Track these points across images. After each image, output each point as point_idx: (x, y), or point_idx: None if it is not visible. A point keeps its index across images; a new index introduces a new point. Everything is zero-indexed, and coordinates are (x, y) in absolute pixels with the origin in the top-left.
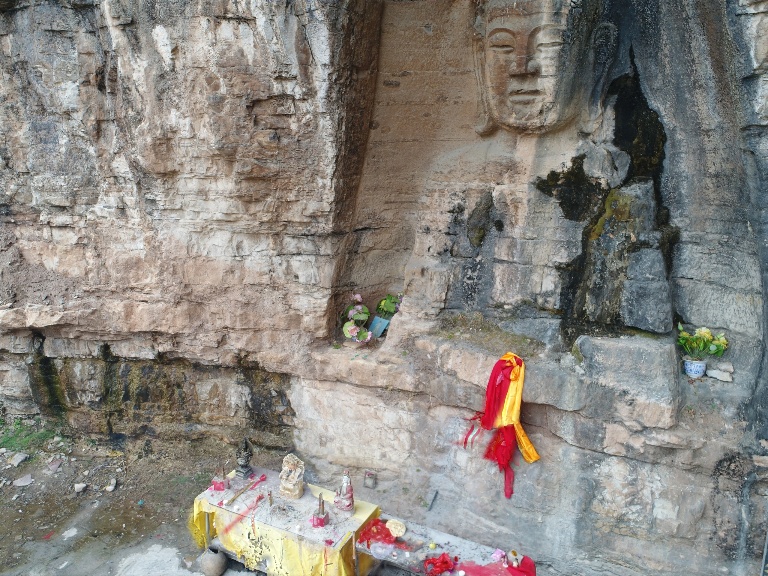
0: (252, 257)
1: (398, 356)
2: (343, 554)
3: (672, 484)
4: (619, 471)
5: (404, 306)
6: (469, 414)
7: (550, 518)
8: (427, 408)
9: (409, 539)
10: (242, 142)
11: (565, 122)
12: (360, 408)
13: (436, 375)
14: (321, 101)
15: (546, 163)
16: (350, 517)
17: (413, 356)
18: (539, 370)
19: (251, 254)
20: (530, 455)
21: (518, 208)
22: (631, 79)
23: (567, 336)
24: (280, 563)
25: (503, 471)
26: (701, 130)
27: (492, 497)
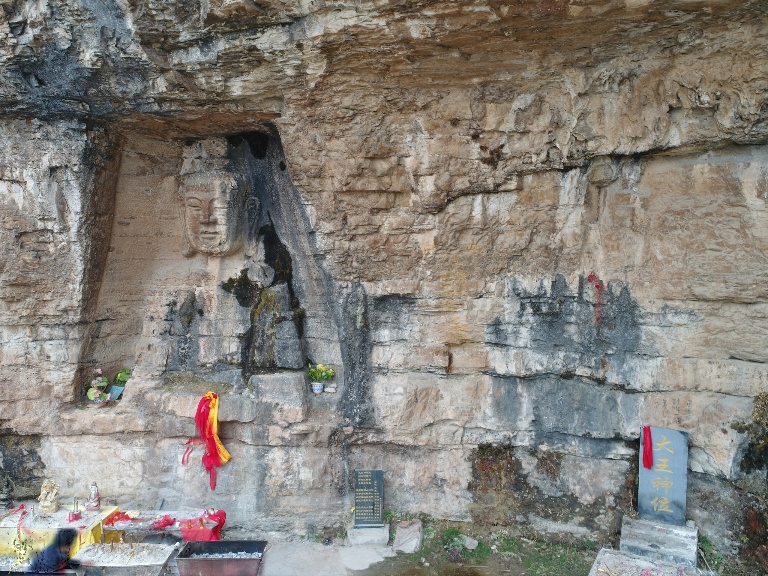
0: (10, 344)
1: (132, 407)
2: (94, 533)
3: (308, 457)
4: (279, 455)
5: (136, 372)
6: (185, 440)
7: (240, 496)
8: (155, 442)
9: (142, 517)
10: (10, 260)
11: (235, 250)
12: (102, 451)
13: (161, 416)
14: (73, 234)
15: (226, 273)
16: (98, 514)
17: (143, 406)
18: (228, 400)
19: (9, 341)
20: (225, 455)
21: (212, 301)
22: (270, 227)
23: (246, 378)
24: (42, 556)
25: (209, 472)
26: (306, 256)
27: (202, 492)
